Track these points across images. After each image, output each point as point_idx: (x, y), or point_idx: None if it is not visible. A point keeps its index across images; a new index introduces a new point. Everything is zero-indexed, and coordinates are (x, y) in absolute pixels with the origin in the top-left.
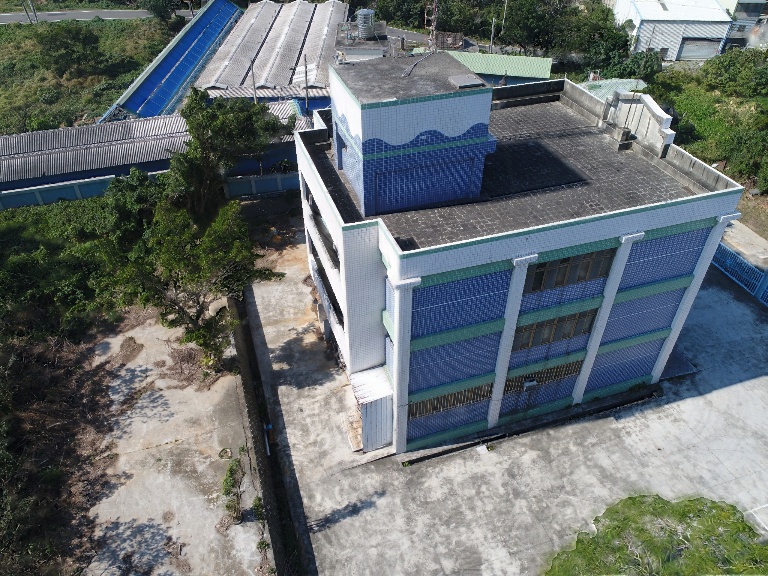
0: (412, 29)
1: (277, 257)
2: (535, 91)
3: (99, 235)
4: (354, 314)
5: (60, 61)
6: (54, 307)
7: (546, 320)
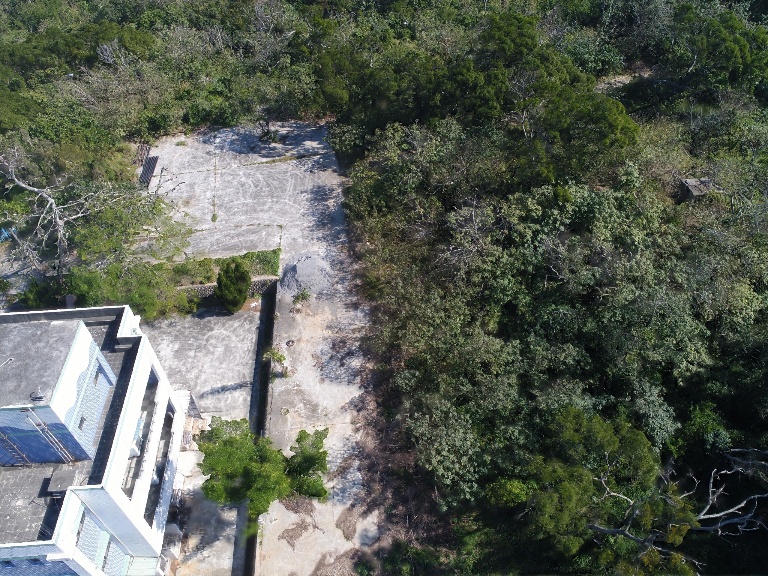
0: None
1: None
2: None
3: None
4: None
5: None
6: None
7: None
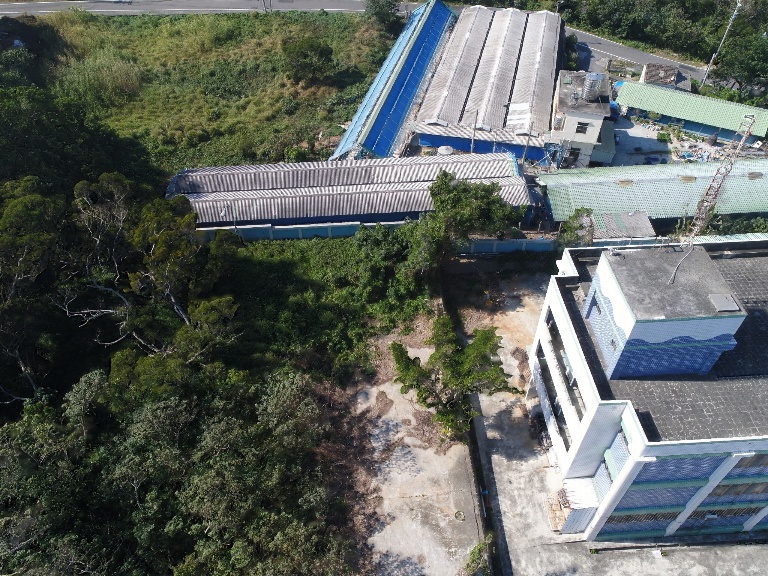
0: (619, 40)
1: (489, 322)
2: (767, 245)
3: (351, 283)
4: (584, 448)
5: (300, 72)
6: (326, 353)
7: (742, 483)
